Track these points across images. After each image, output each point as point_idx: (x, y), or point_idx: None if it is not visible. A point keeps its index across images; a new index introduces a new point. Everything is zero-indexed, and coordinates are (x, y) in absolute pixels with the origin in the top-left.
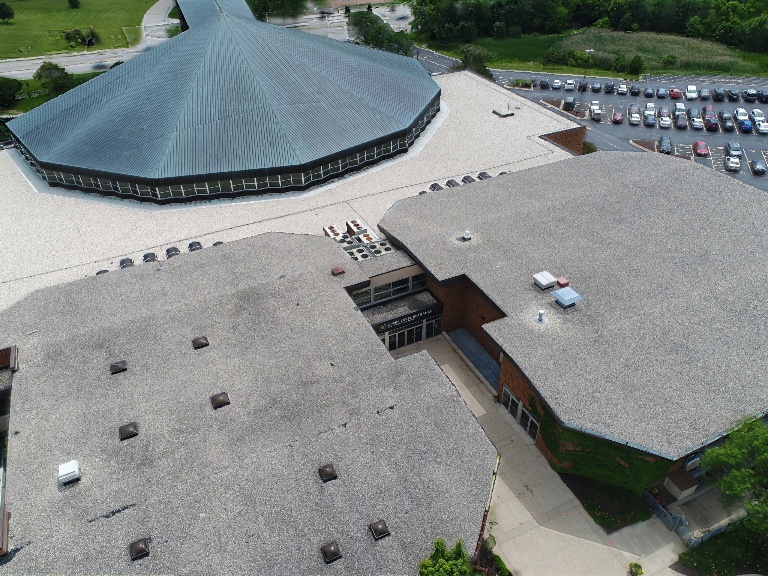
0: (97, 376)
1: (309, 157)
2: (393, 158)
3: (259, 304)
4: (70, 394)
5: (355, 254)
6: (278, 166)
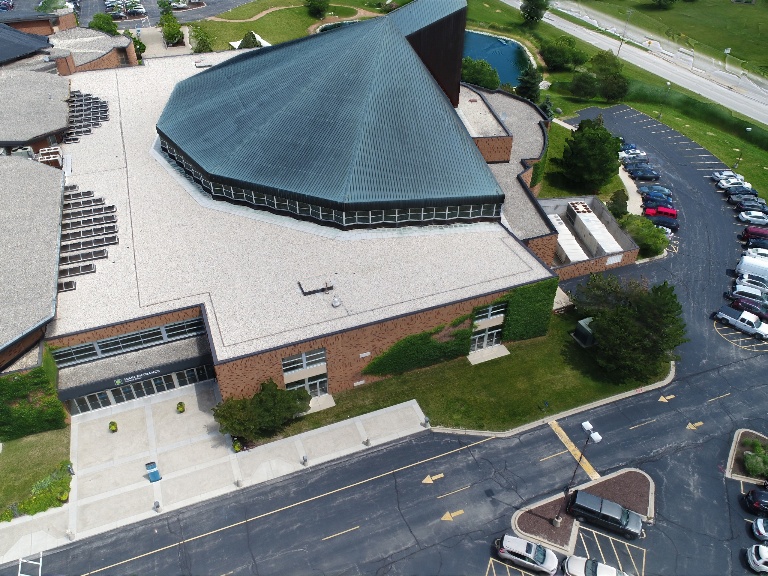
0: None
1: (165, 126)
2: (203, 191)
3: None
4: None
5: None
6: (160, 117)
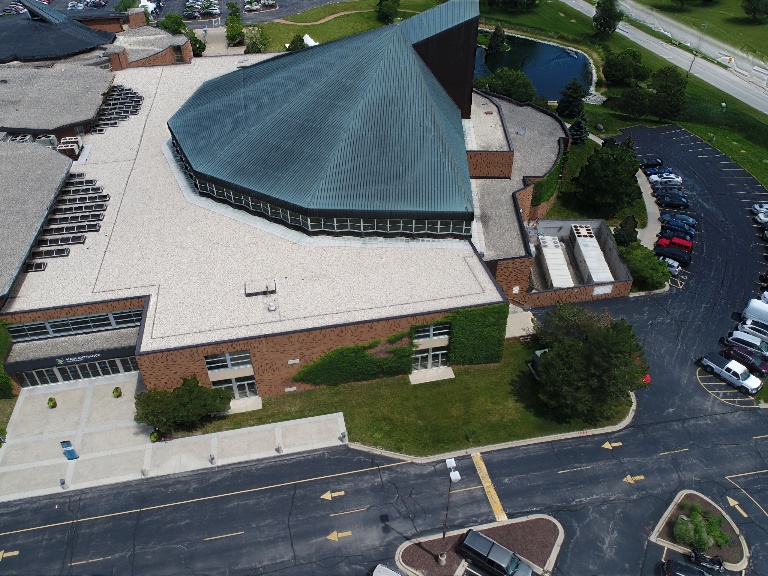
0: (5, 79)
1: (174, 123)
2: (193, 187)
3: (1, 104)
4: (1, 76)
5: (22, 137)
6: (174, 114)
